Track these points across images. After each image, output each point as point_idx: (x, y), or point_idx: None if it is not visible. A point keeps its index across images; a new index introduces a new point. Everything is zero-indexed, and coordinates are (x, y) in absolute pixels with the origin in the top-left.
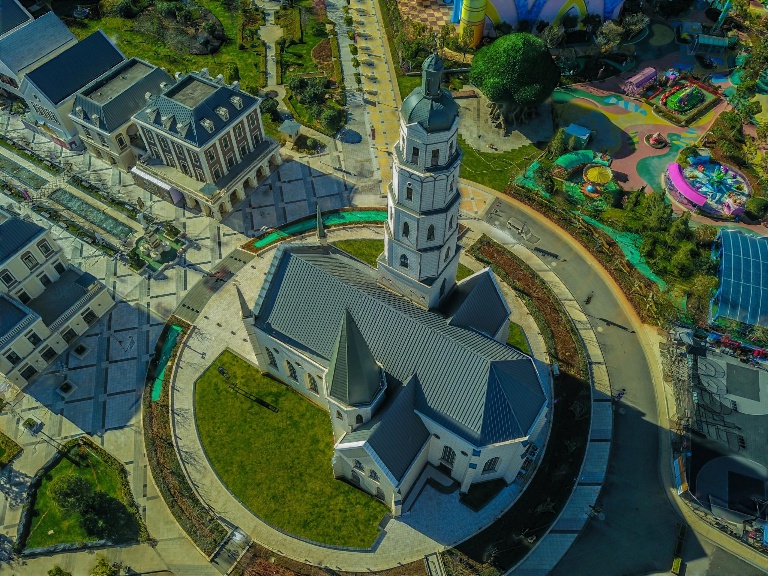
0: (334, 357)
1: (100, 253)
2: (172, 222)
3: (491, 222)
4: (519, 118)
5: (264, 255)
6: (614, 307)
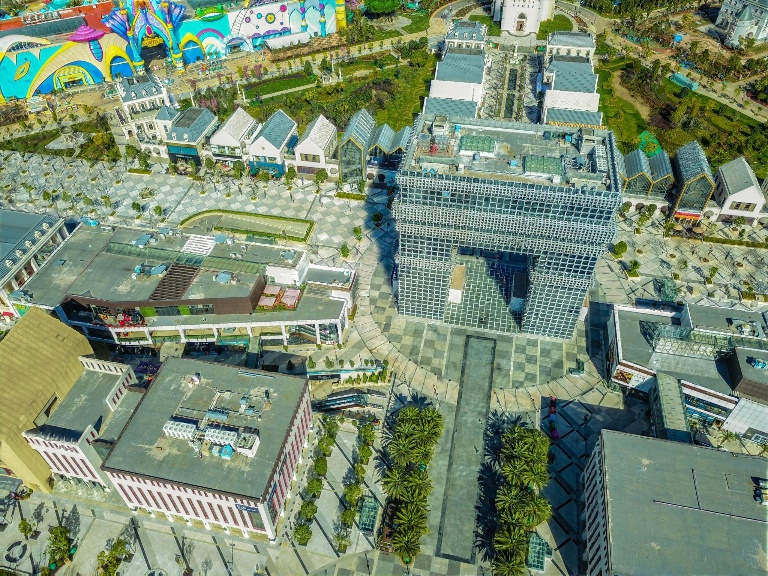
0: None
1: (527, 71)
2: (500, 63)
3: (445, 17)
4: None
5: None
6: None
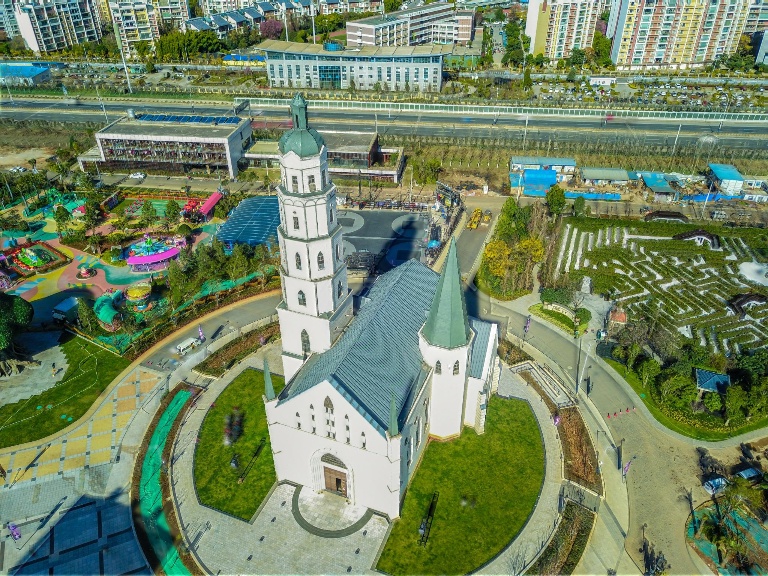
0: (457, 302)
1: None
2: None
3: (174, 367)
4: (18, 350)
5: (214, 571)
6: (277, 298)
